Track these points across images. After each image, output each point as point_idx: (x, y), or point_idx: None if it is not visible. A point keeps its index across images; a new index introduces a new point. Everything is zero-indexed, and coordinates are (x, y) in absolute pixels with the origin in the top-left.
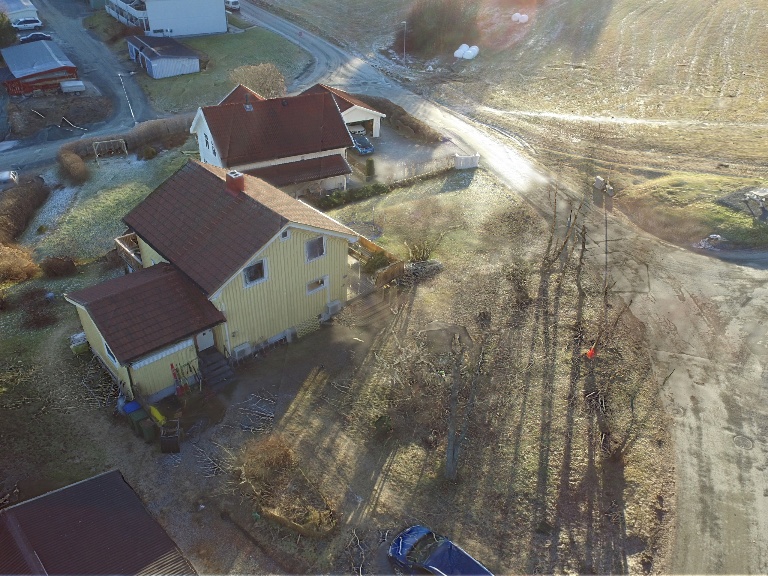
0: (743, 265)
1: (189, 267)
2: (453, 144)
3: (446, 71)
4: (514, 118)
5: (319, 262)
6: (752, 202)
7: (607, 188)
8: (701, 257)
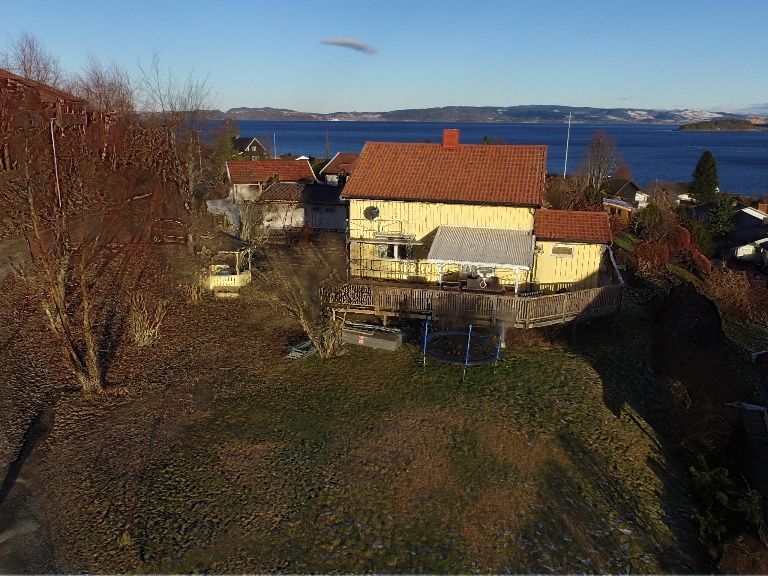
0: None
1: None
2: None
3: None
4: None
5: None
6: None
7: None
8: None
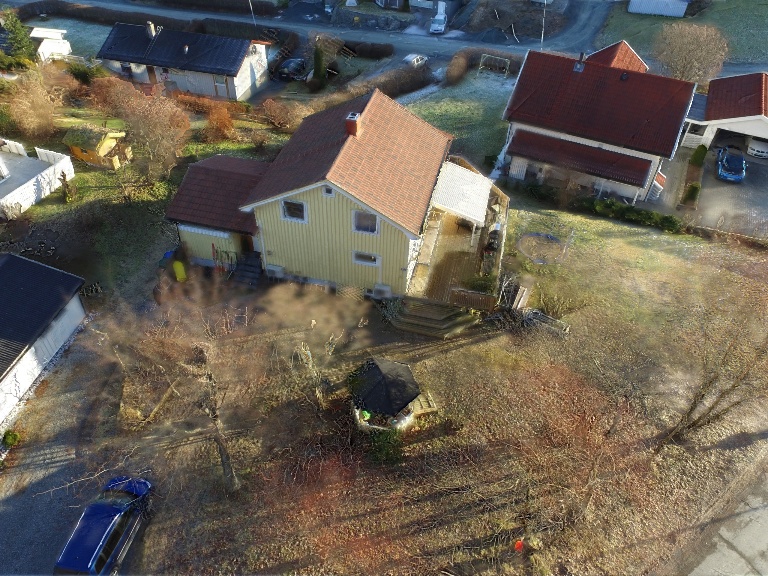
0: None
1: (265, 177)
2: None
3: None
4: None
5: (371, 238)
6: None
7: None
8: None
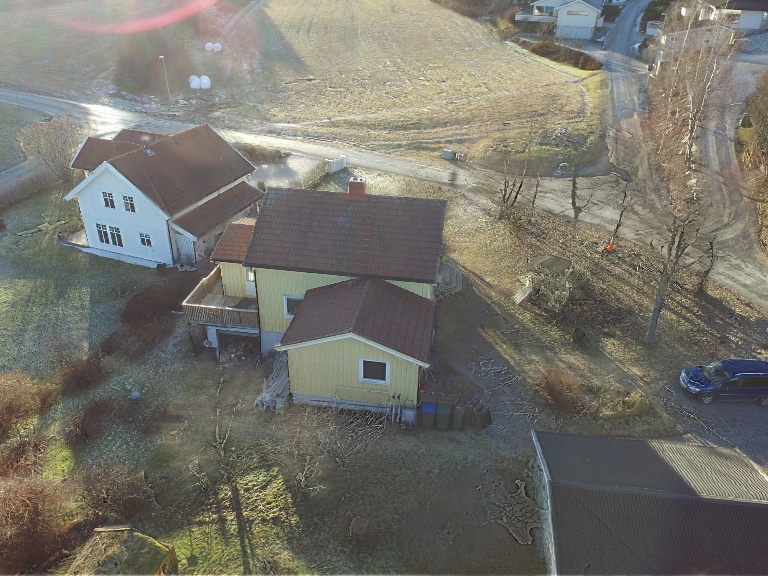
0: (596, 176)
1: (386, 270)
2: (298, 156)
3: (201, 102)
4: (314, 127)
5: None
6: (558, 139)
7: (458, 156)
8: None
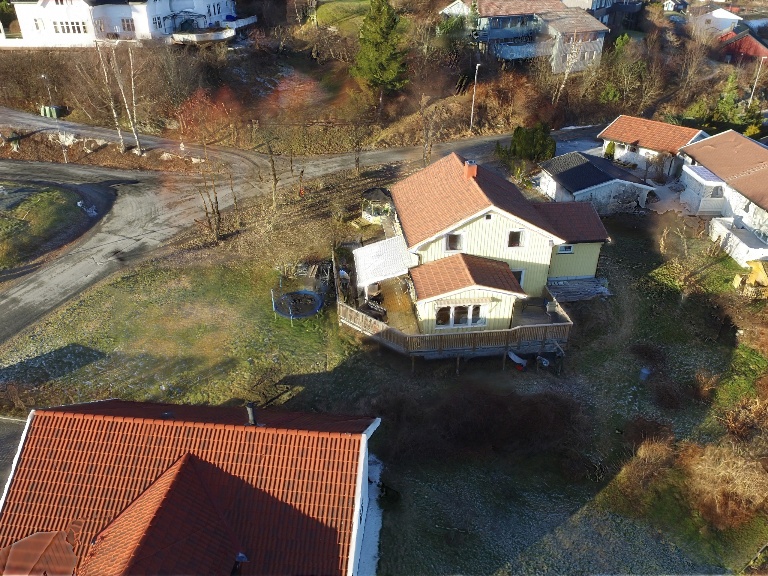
0: (117, 194)
1: None
2: None
3: None
4: None
5: None
6: (0, 197)
7: None
8: (118, 206)
